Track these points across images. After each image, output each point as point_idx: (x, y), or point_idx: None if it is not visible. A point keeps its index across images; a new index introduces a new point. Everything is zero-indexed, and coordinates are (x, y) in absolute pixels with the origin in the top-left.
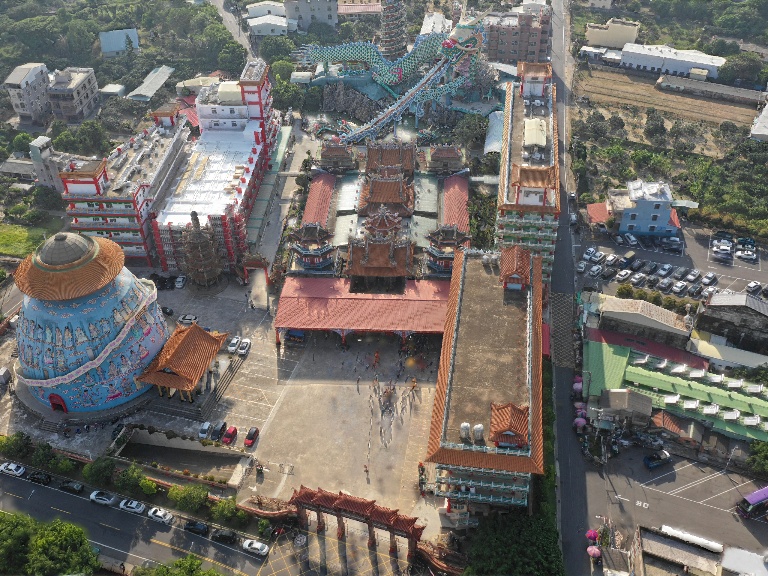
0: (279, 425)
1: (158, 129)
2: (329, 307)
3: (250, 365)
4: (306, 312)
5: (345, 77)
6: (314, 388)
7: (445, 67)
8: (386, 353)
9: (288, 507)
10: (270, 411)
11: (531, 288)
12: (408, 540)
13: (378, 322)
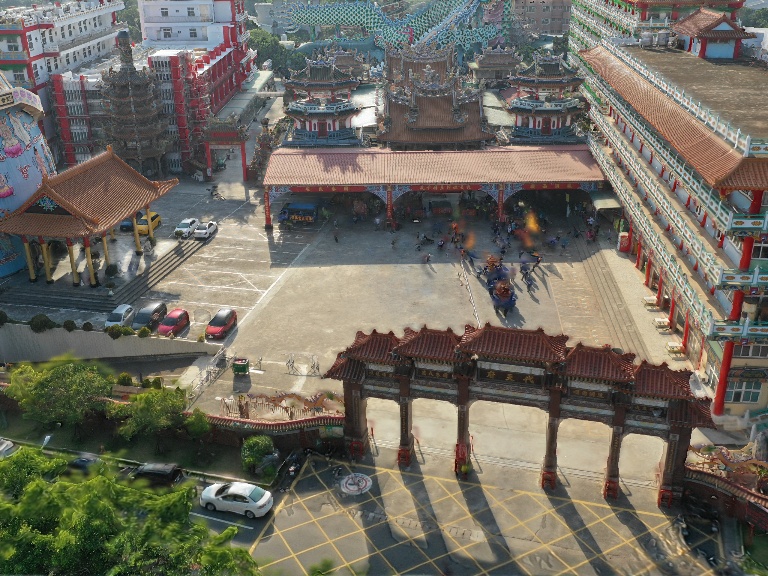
0: (279, 312)
1: (78, 2)
2: (360, 162)
3: (216, 249)
4: (319, 168)
5: (339, 42)
6: (344, 268)
7: (474, 5)
8: (469, 230)
9: (317, 414)
10: (259, 296)
11: (754, 49)
12: (666, 443)
13: (452, 174)
